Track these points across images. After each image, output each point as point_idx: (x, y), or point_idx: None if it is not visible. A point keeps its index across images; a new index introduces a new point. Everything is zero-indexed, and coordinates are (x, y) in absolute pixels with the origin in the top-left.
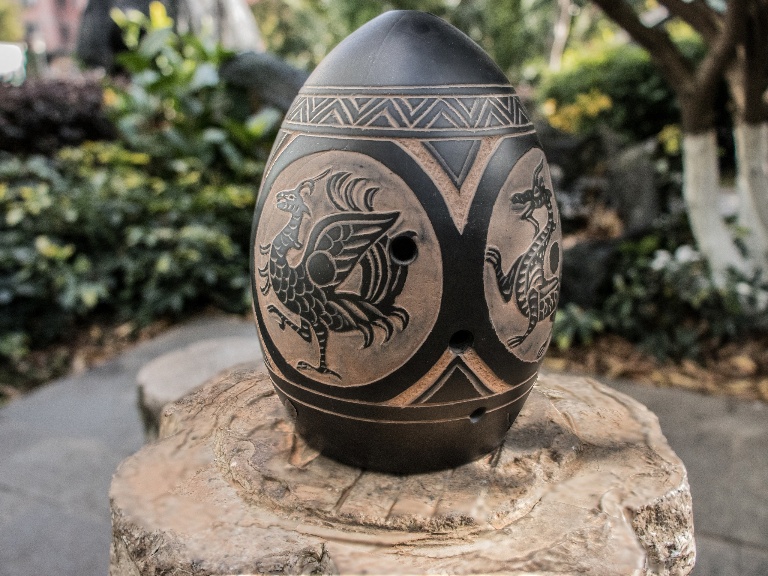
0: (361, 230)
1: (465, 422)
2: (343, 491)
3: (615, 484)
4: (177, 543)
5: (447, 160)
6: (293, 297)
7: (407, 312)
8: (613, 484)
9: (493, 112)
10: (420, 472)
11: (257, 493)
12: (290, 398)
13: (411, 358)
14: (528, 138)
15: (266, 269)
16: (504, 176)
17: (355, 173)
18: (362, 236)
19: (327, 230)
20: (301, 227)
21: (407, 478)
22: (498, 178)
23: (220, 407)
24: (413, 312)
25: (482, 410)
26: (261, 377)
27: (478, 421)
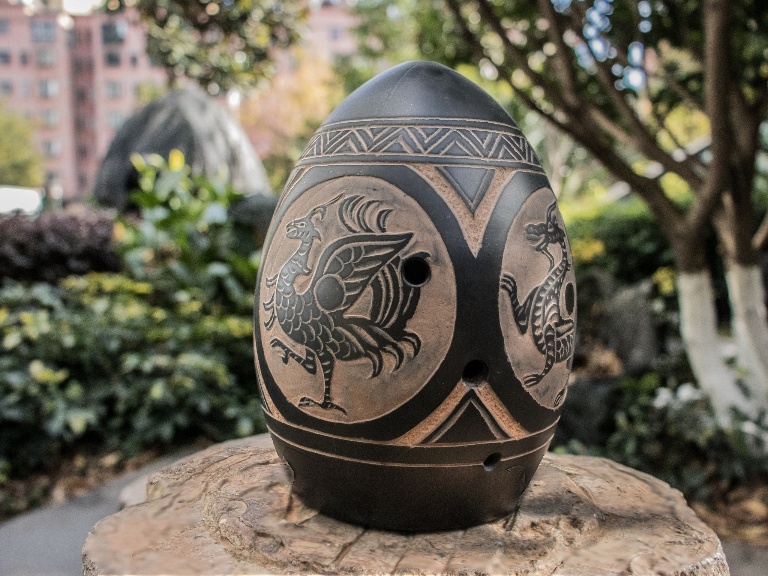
0: (373, 251)
1: (479, 469)
2: (343, 546)
3: (644, 550)
4: None
5: (461, 185)
6: (299, 326)
7: (419, 337)
8: (641, 550)
9: (506, 147)
10: (428, 531)
11: (248, 548)
12: (289, 444)
13: (422, 389)
14: (540, 177)
15: (272, 301)
16: (518, 206)
17: (368, 196)
18: (374, 257)
19: (338, 253)
20: (311, 252)
21: (414, 537)
22: (512, 207)
23: (211, 476)
24: (425, 337)
25: (497, 457)
26: (256, 451)
27: (492, 470)
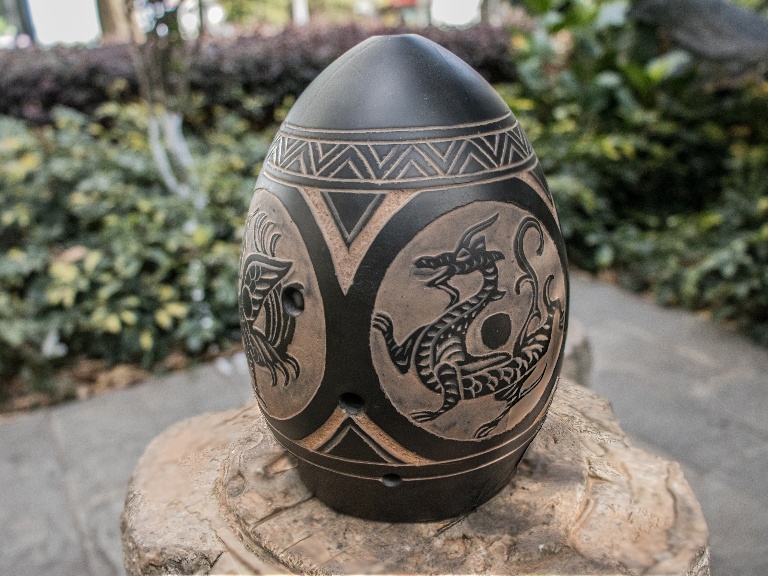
0: (266, 274)
1: (378, 483)
2: (276, 509)
3: None
4: (137, 507)
5: (341, 214)
6: None
7: (298, 362)
8: None
9: (414, 161)
10: (356, 516)
11: (223, 485)
12: None
13: (306, 407)
14: (470, 190)
15: None
16: (409, 236)
17: (269, 216)
18: (265, 280)
19: (250, 267)
20: (242, 259)
21: (343, 517)
22: (399, 238)
23: None
24: (303, 364)
25: (397, 476)
26: None
27: (396, 486)
